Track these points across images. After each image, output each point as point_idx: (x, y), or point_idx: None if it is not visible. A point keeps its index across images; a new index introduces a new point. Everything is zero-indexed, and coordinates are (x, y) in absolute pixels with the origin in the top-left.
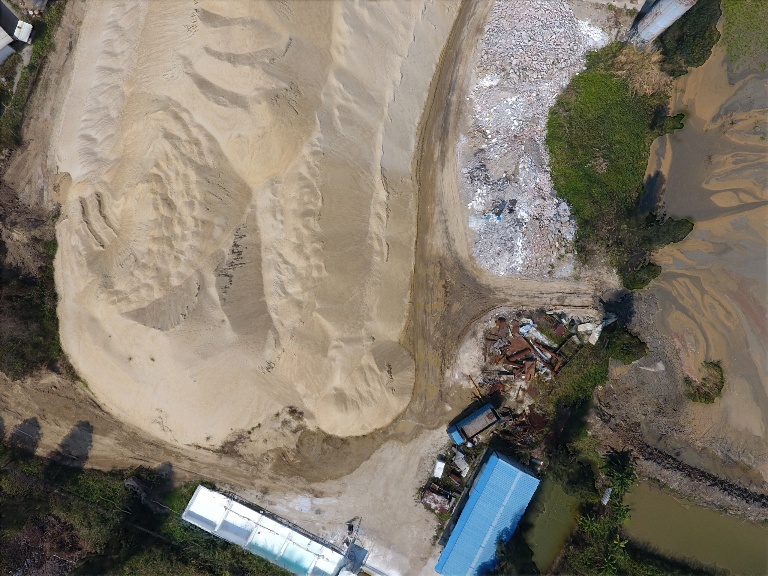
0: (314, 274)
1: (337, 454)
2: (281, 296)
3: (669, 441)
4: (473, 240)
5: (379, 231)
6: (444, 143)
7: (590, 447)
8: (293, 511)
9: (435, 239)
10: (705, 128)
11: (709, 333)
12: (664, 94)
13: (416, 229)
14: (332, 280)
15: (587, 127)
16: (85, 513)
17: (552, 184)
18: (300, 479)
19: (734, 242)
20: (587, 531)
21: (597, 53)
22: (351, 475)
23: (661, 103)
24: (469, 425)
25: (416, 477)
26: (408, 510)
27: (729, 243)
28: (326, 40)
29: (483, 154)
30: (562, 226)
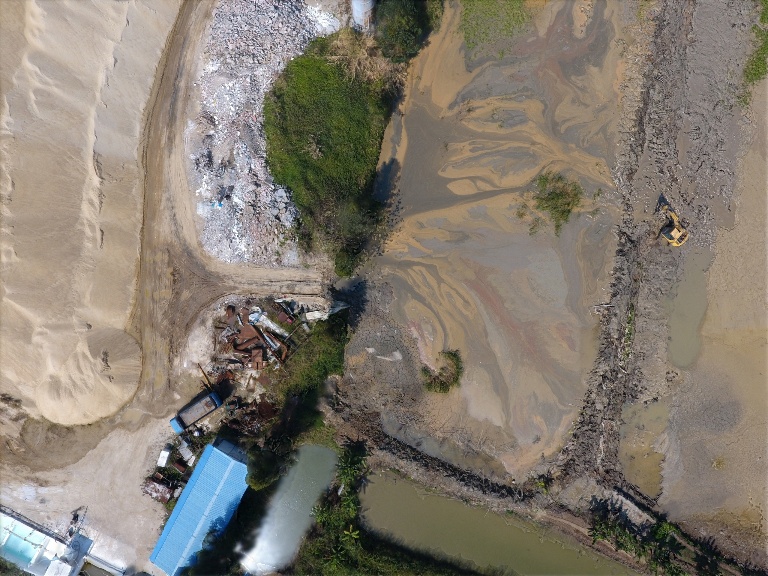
0: (3, 259)
1: (63, 443)
2: None
3: (409, 431)
4: (202, 227)
5: (91, 217)
6: (171, 129)
7: (327, 437)
8: (17, 500)
9: (163, 226)
10: (441, 115)
11: (446, 322)
12: (392, 80)
13: (142, 216)
14: (26, 266)
15: (301, 113)
16: None
17: (269, 170)
18: (25, 468)
19: (472, 230)
20: (318, 521)
21: (325, 39)
22: (77, 464)
23: (391, 90)
24: (187, 413)
25: (143, 466)
26: (135, 500)
27: (466, 231)
28: (18, 23)
29: (209, 140)
30: (280, 213)
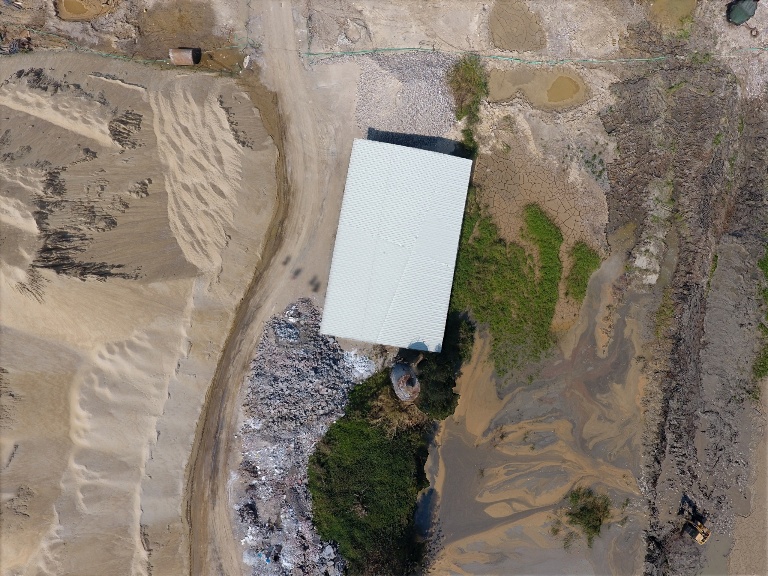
0: None
1: None
2: None
3: None
4: (248, 574)
5: None
6: (214, 481)
7: None
8: None
9: None
10: (476, 443)
11: None
12: (429, 422)
13: (189, 570)
14: None
15: (346, 475)
16: None
17: (315, 530)
18: None
19: (510, 550)
20: None
21: (362, 386)
22: None
23: (428, 429)
24: None
25: None
26: None
27: (505, 552)
28: (63, 427)
29: (253, 492)
30: (329, 568)
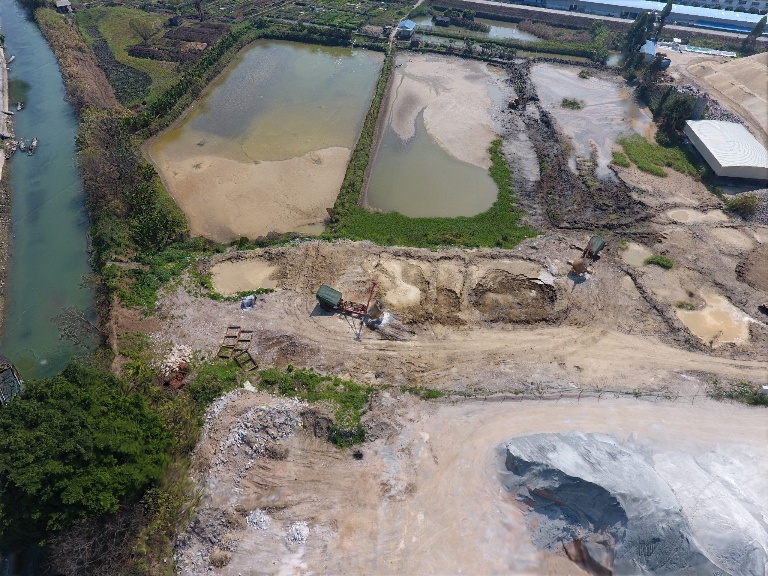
0: None
1: None
2: (761, 64)
3: None
4: None
5: None
6: None
7: None
8: None
9: (714, 93)
10: None
11: None
12: None
13: None
14: None
15: None
16: (765, 50)
17: None
18: None
19: None
20: None
21: None
22: None
23: None
24: None
25: None
26: None
27: None
28: None
29: None
30: None
